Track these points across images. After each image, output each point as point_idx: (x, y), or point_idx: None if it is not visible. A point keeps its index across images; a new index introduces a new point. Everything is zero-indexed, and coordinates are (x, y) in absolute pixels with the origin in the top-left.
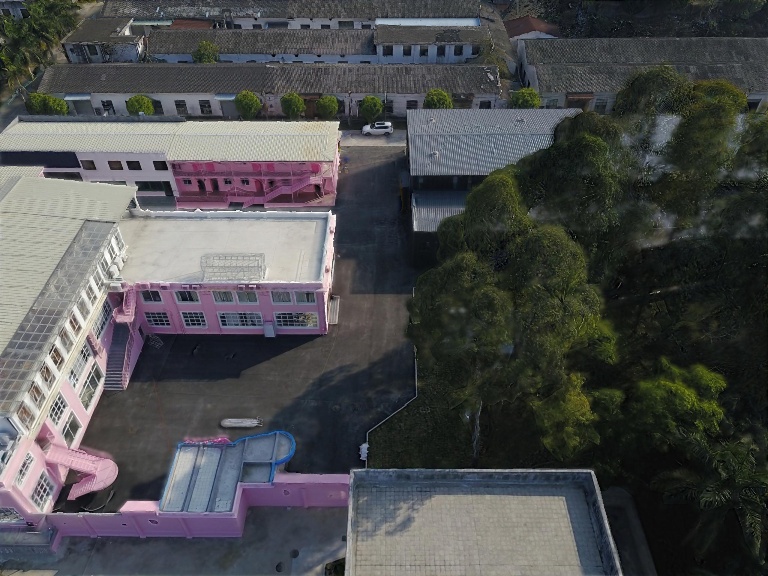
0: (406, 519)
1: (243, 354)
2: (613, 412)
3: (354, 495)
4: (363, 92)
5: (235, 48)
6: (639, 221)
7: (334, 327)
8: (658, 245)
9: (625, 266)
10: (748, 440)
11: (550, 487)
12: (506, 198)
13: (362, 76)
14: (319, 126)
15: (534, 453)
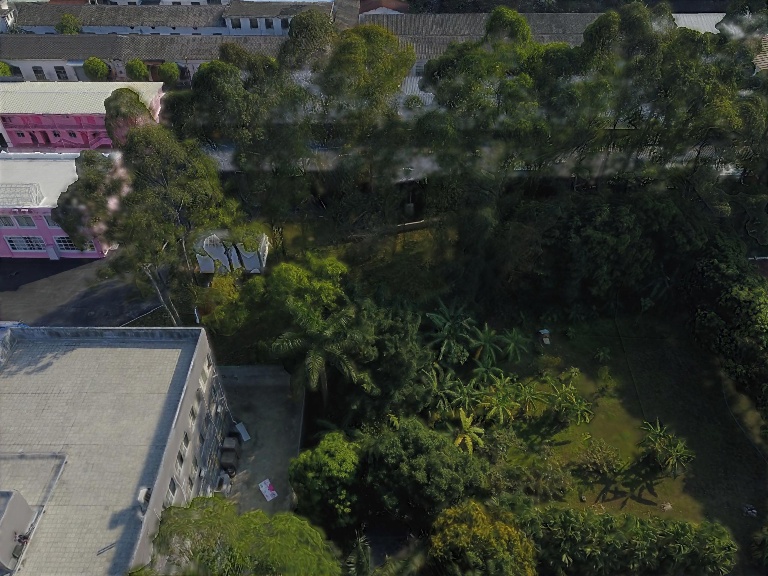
0: (45, 364)
1: (26, 273)
2: (264, 295)
3: (12, 348)
4: (202, 59)
5: (97, 21)
6: (281, 136)
7: (113, 252)
8: (328, 163)
9: (314, 185)
10: (350, 310)
11: (174, 343)
12: (126, 106)
13: (204, 45)
14: (141, 85)
15: (246, 347)
